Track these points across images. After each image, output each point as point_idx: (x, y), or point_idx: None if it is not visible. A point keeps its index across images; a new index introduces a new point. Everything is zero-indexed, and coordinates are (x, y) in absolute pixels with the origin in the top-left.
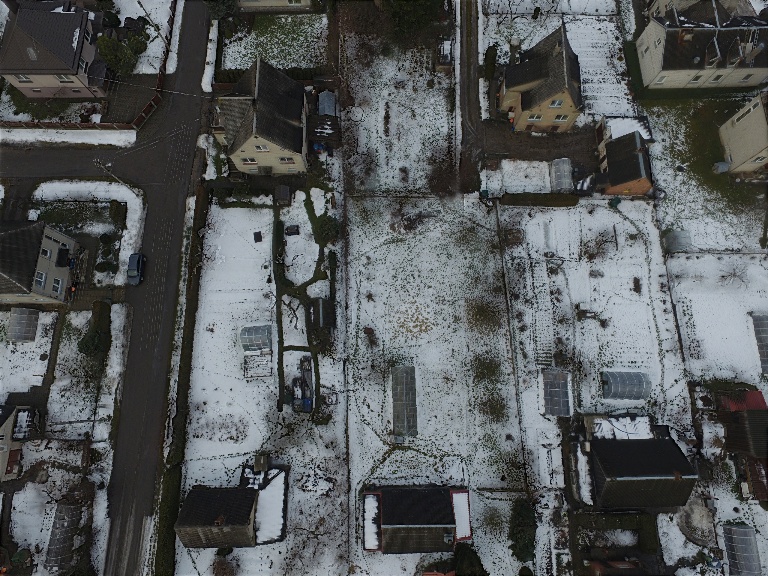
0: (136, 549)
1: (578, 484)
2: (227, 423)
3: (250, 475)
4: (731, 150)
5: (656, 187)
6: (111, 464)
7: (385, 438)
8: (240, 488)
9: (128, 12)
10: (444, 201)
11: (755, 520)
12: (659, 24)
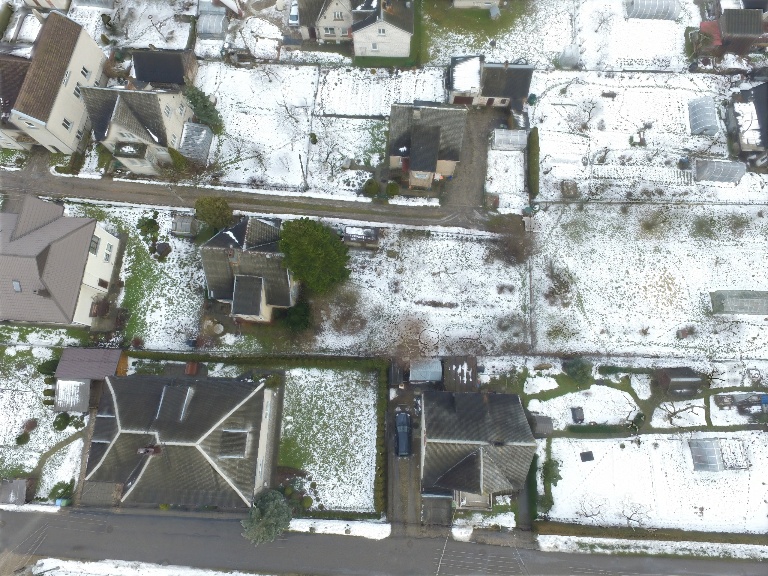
0: None
1: None
2: None
3: None
4: (483, 1)
5: None
6: None
7: None
8: None
9: None
10: (534, 251)
11: None
12: (369, 26)
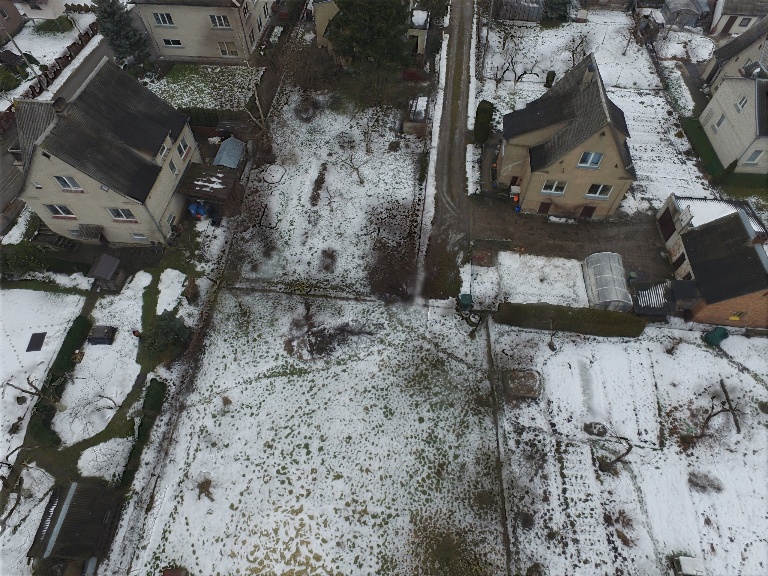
0: None
1: None
2: None
3: None
4: None
5: None
6: None
7: None
8: None
9: (19, 53)
10: (392, 309)
11: None
12: (740, 78)
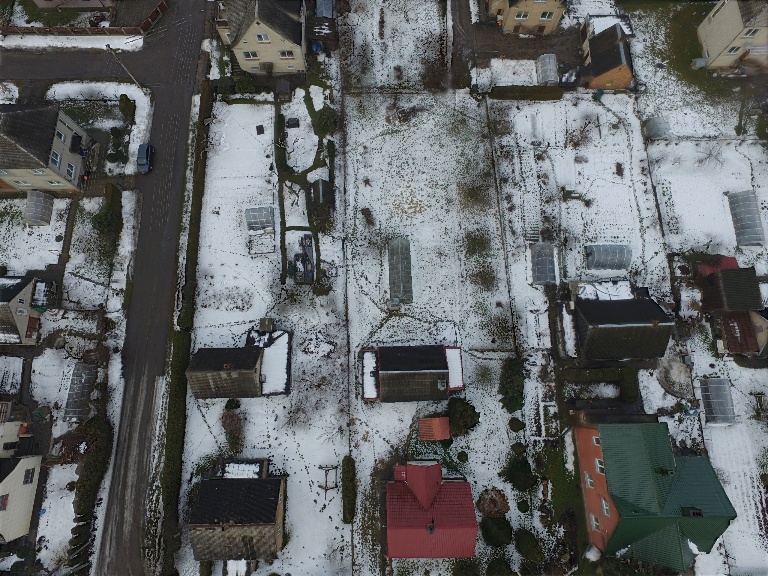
0: (149, 405)
1: (563, 340)
2: (233, 294)
3: (256, 336)
4: (708, 46)
5: (637, 82)
6: (124, 331)
7: (382, 306)
8: (246, 346)
9: None
10: (436, 96)
11: (730, 375)
12: None
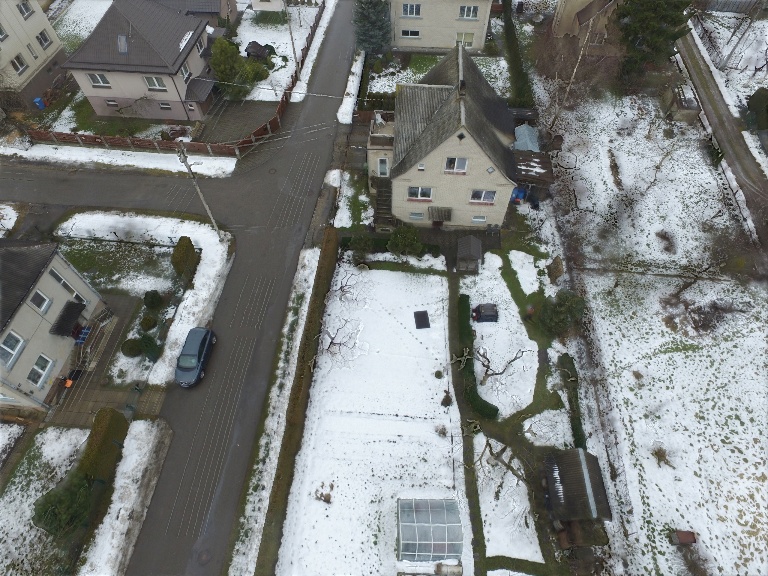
0: None
1: None
2: None
3: None
4: None
5: None
6: None
7: None
8: None
9: None
10: (750, 288)
11: None
12: None
